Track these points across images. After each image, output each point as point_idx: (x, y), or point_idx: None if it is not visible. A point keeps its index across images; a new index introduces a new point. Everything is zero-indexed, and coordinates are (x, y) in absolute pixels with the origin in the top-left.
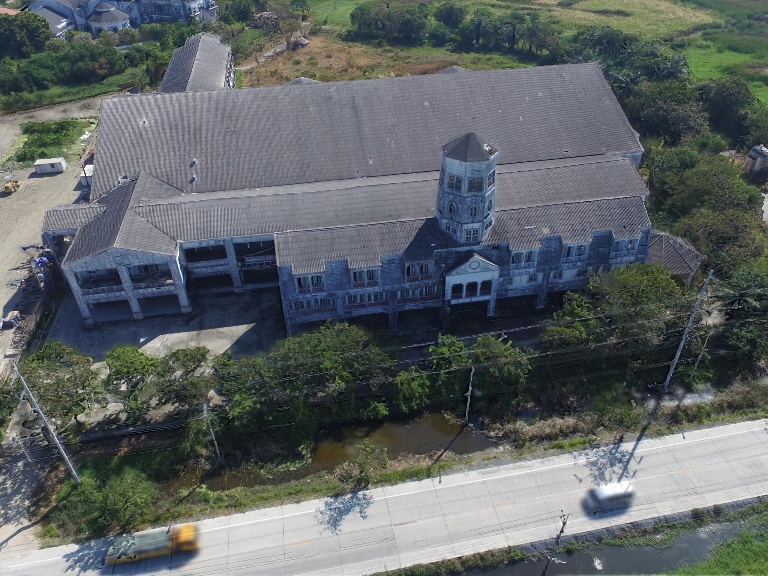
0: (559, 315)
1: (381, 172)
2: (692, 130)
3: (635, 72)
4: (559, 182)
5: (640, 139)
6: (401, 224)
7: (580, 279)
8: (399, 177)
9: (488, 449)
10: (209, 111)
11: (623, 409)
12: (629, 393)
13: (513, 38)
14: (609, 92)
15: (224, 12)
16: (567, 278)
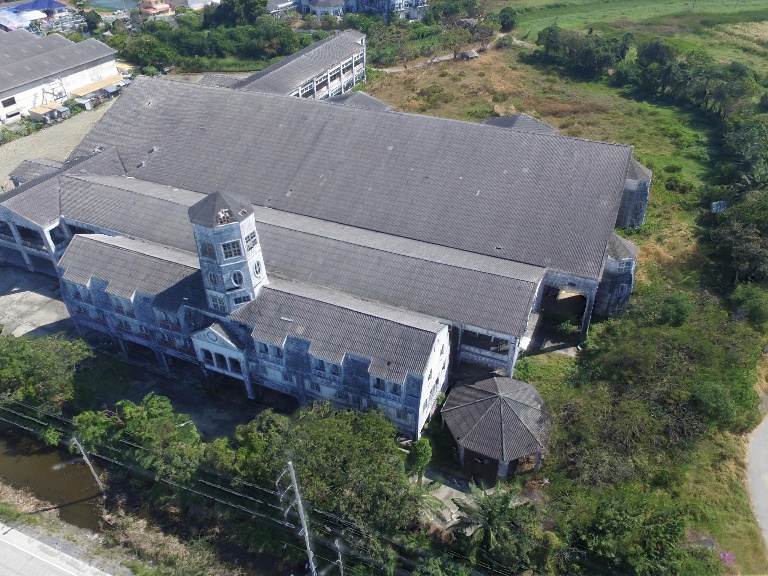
0: (239, 430)
1: (289, 207)
2: (764, 276)
3: (767, 174)
4: (426, 281)
5: (718, 265)
6: (175, 266)
7: (343, 402)
8: (291, 218)
9: (86, 529)
10: (201, 106)
11: (246, 573)
12: (276, 559)
13: (703, 94)
14: (617, 191)
15: (427, 12)
16: (327, 394)
